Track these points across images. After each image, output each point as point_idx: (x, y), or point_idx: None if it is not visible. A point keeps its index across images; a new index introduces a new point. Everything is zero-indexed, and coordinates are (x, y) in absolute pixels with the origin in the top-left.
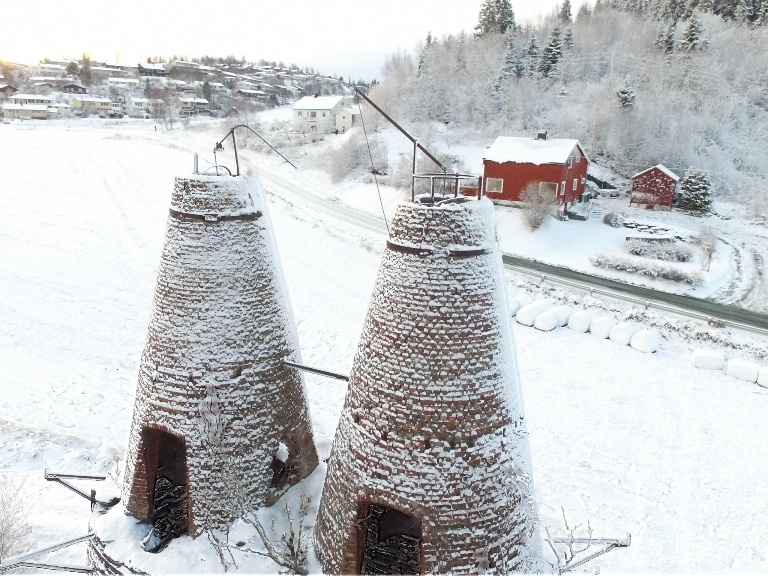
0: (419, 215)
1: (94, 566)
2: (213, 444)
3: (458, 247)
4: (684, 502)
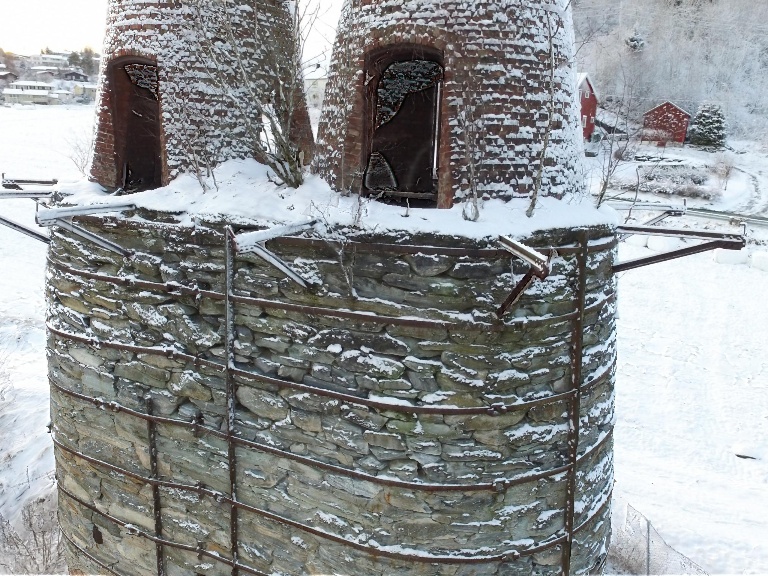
0: None
1: (51, 233)
2: None
3: None
4: (714, 360)
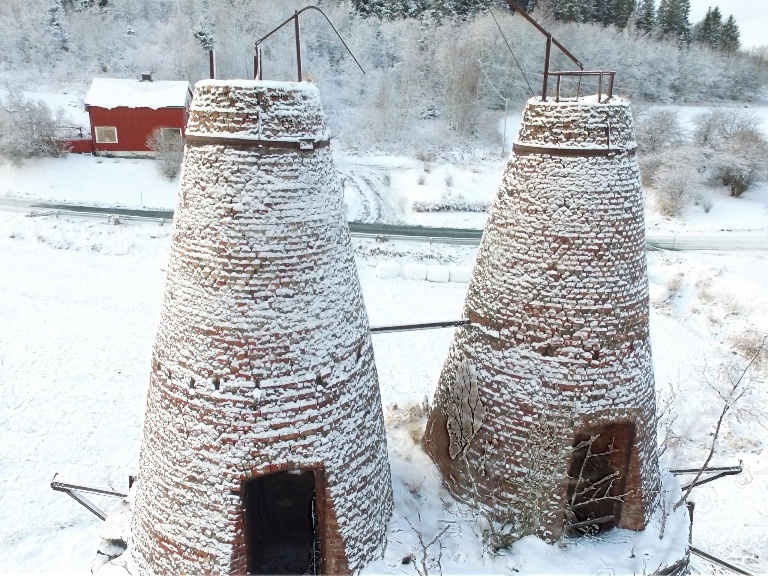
0: (600, 113)
1: None
2: (465, 435)
3: (633, 144)
4: None
